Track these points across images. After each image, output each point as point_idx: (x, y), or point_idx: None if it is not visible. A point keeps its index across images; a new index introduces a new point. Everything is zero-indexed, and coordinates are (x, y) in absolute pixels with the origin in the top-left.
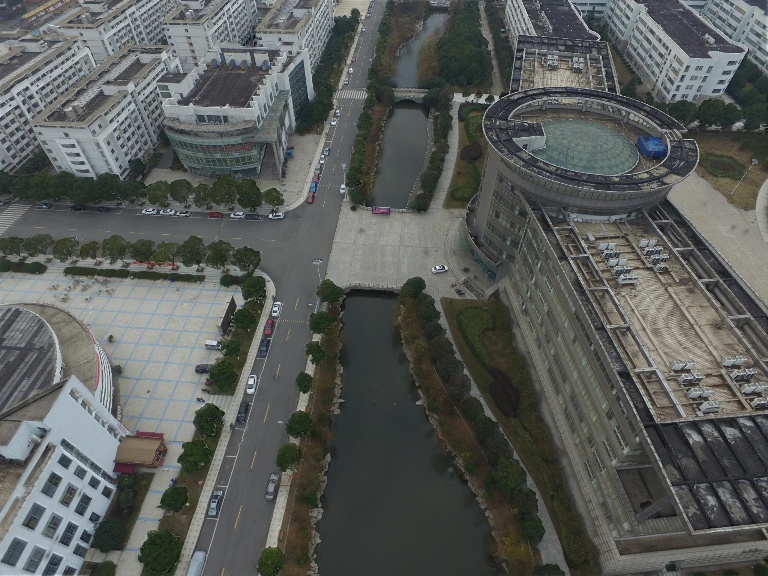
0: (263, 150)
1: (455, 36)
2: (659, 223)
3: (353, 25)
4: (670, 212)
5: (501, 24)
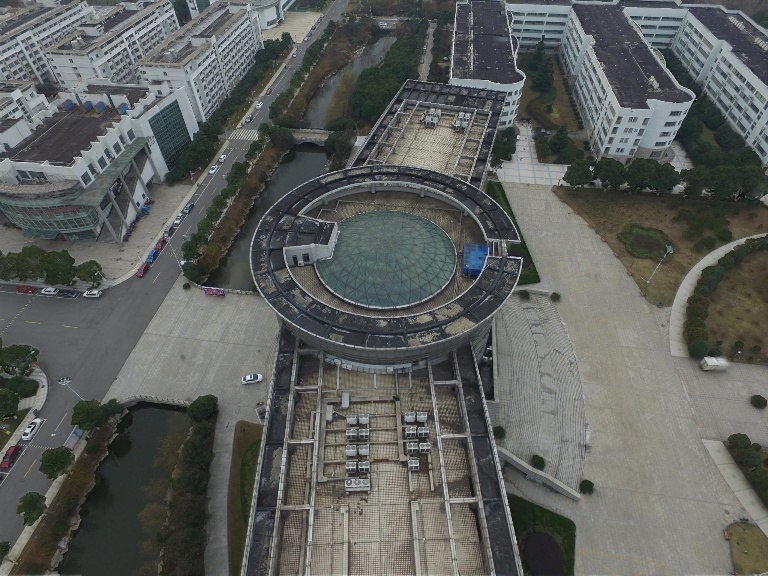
0: (108, 207)
1: (383, 67)
2: (442, 385)
3: (277, 52)
4: (468, 364)
5: (447, 51)
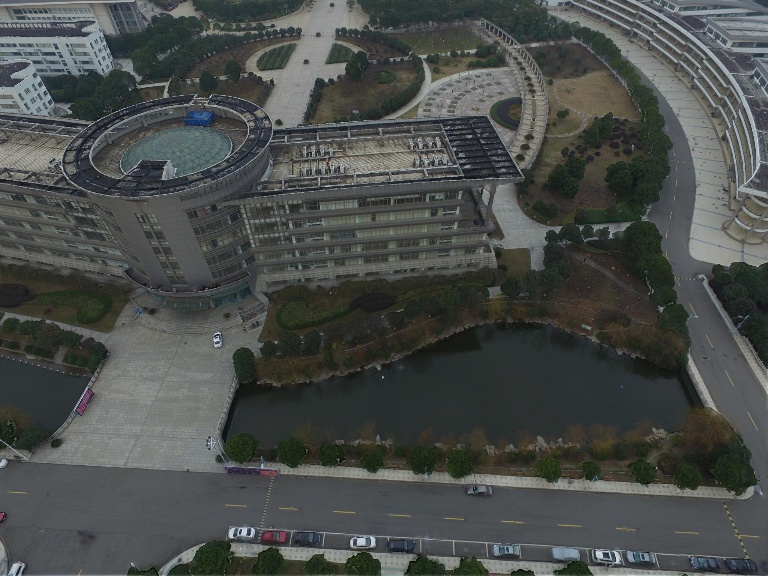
0: None
1: None
2: None
3: None
4: (274, 135)
5: None
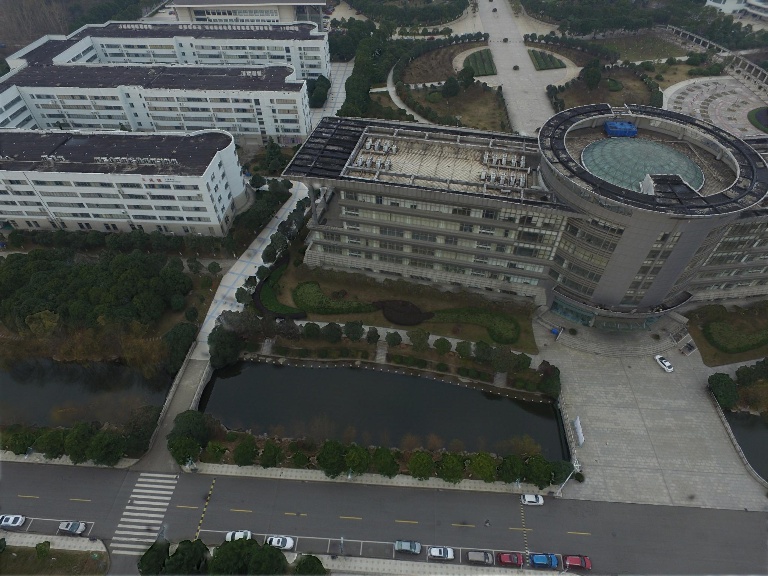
0: None
1: (4, 290)
2: None
3: None
4: None
5: None
